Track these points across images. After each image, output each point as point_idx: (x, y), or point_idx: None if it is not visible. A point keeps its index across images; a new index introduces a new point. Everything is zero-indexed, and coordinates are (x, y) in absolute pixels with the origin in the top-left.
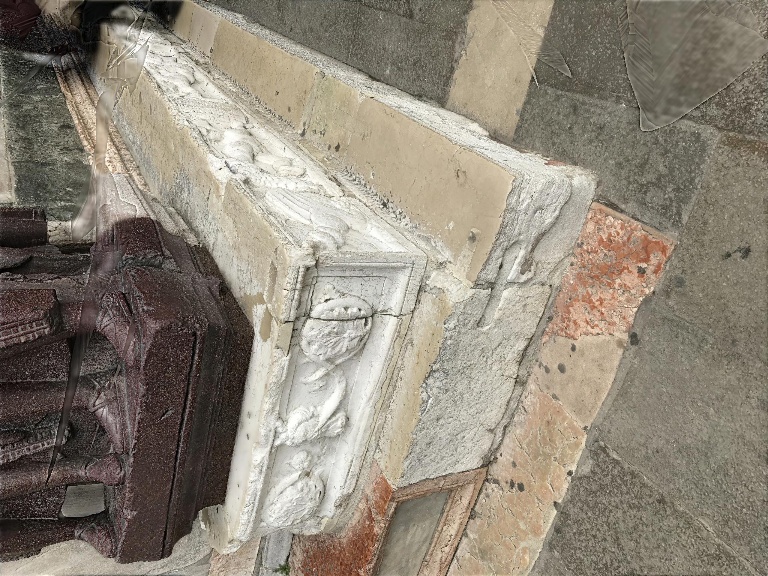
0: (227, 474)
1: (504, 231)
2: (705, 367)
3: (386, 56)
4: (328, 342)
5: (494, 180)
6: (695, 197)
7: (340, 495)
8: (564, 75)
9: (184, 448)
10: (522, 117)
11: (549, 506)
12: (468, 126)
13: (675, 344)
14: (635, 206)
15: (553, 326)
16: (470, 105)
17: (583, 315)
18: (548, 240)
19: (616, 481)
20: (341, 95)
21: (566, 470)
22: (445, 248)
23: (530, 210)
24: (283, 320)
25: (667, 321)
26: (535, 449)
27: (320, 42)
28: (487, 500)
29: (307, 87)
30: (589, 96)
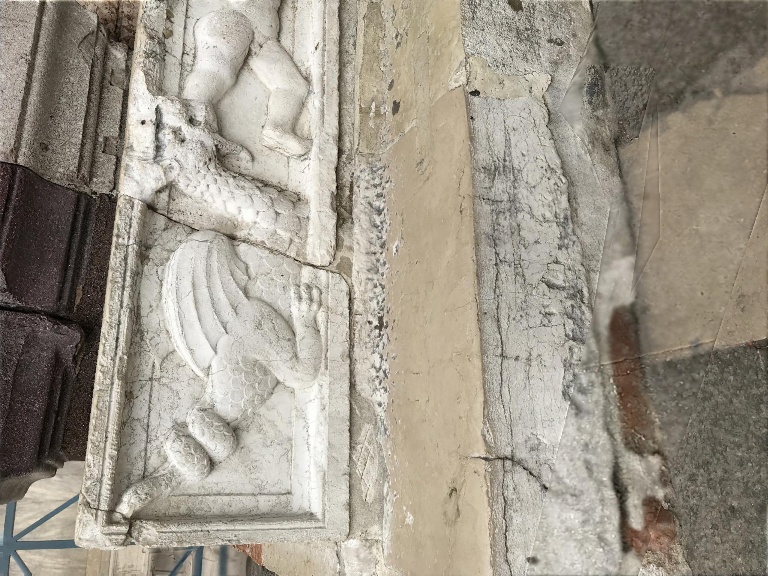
0: None
1: None
2: None
3: None
4: None
5: None
6: None
7: None
8: None
9: None
10: None
11: None
12: None
13: None
14: None
15: None
16: None
17: None
18: None
19: None
20: (441, 18)
21: None
22: (388, 525)
23: None
24: None
25: None
26: None
27: None
28: None
29: None
30: None
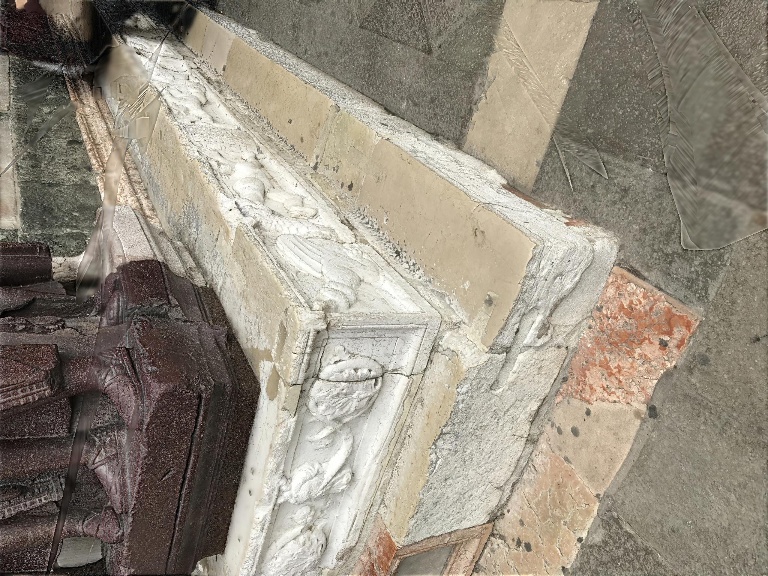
0: (228, 525)
1: (522, 298)
2: (727, 451)
3: (403, 90)
4: (336, 403)
5: (514, 245)
6: (723, 274)
7: (342, 548)
8: (588, 131)
9: (185, 507)
10: (543, 169)
11: (557, 570)
12: (486, 174)
13: (696, 423)
14: (659, 275)
15: (568, 387)
16: (488, 150)
17: (600, 380)
18: (567, 304)
19: (628, 555)
20: (356, 133)
21: (576, 536)
22: (460, 308)
23: (550, 277)
24: (291, 383)
25: (689, 398)
26: (544, 510)
27: (335, 68)
28: (492, 555)
29: (321, 119)
30: (614, 156)
